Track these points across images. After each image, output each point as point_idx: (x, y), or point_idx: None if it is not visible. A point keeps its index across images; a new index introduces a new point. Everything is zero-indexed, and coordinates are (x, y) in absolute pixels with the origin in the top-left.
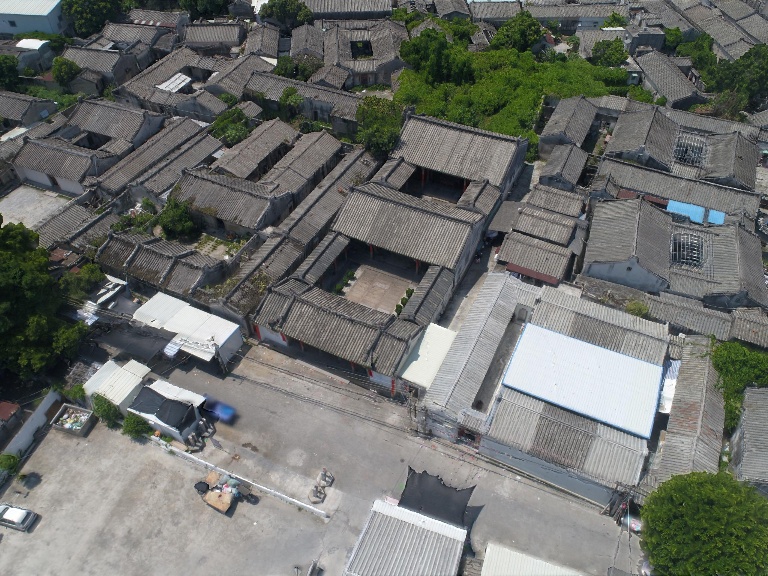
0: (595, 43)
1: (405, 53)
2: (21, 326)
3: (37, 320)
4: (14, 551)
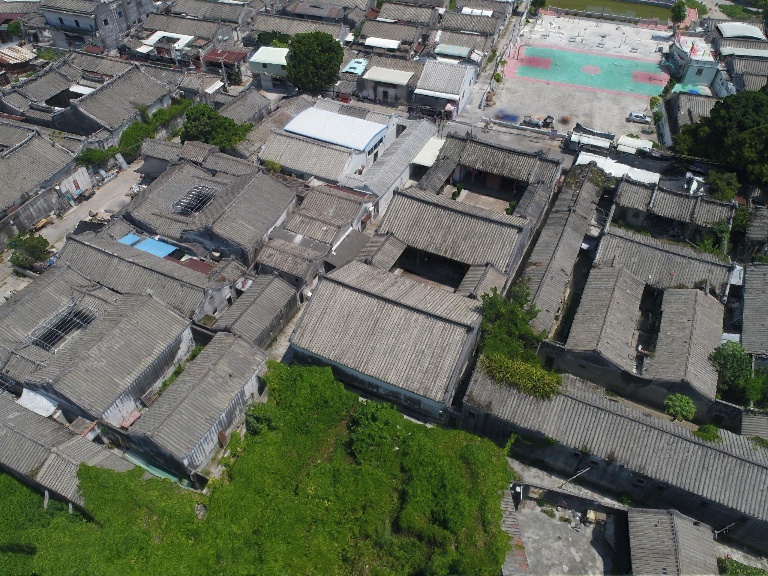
0: None
1: None
2: None
3: (706, 132)
4: (628, 114)
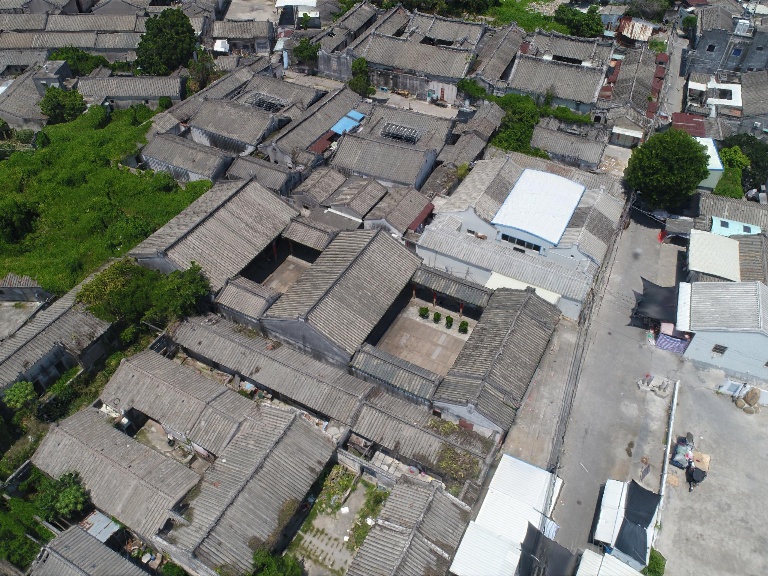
0: (41, 104)
1: None
2: None
3: None
4: None
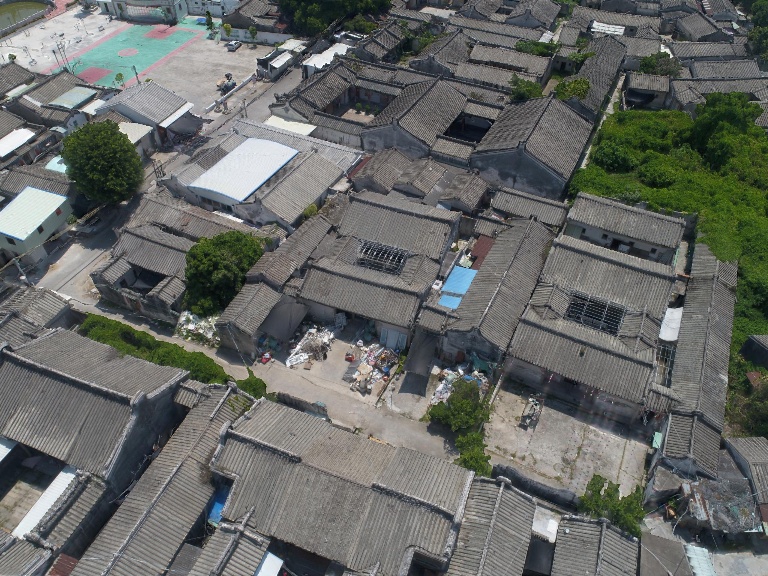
0: None
1: None
2: (312, 4)
3: (316, 7)
4: None
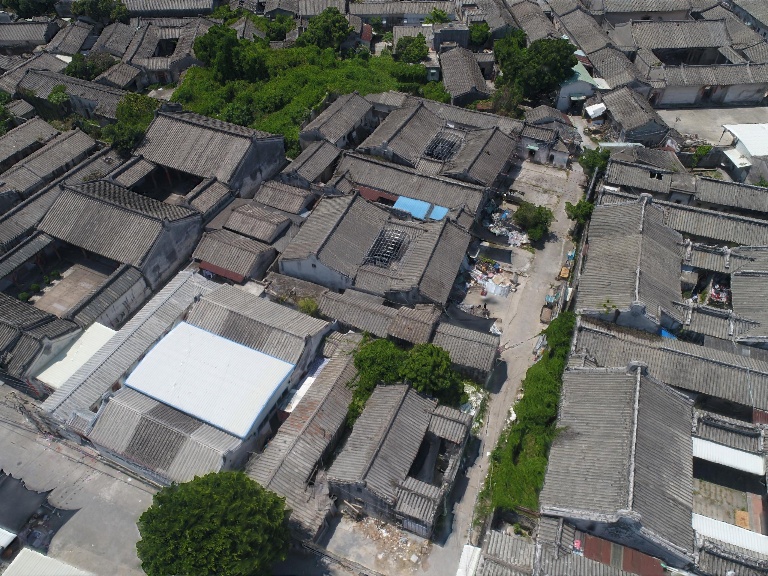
0: (398, 39)
1: (198, 50)
2: None
3: None
4: None
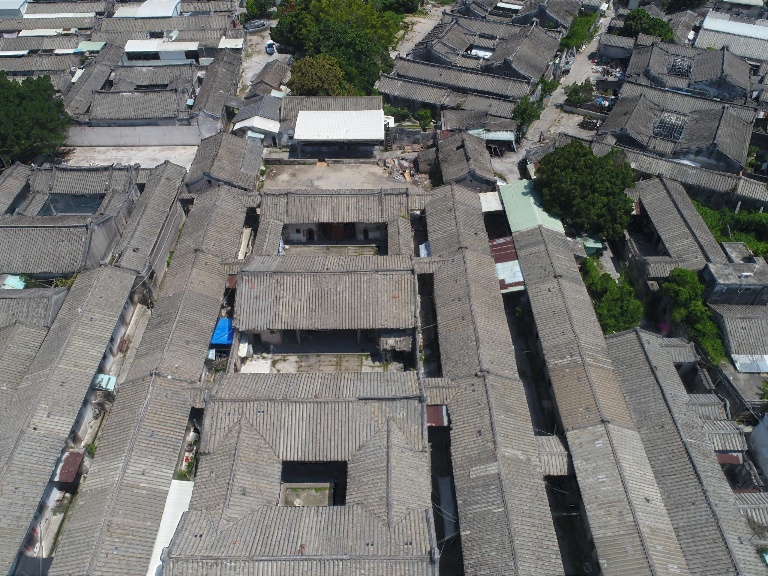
0: None
1: None
2: None
3: None
4: None
